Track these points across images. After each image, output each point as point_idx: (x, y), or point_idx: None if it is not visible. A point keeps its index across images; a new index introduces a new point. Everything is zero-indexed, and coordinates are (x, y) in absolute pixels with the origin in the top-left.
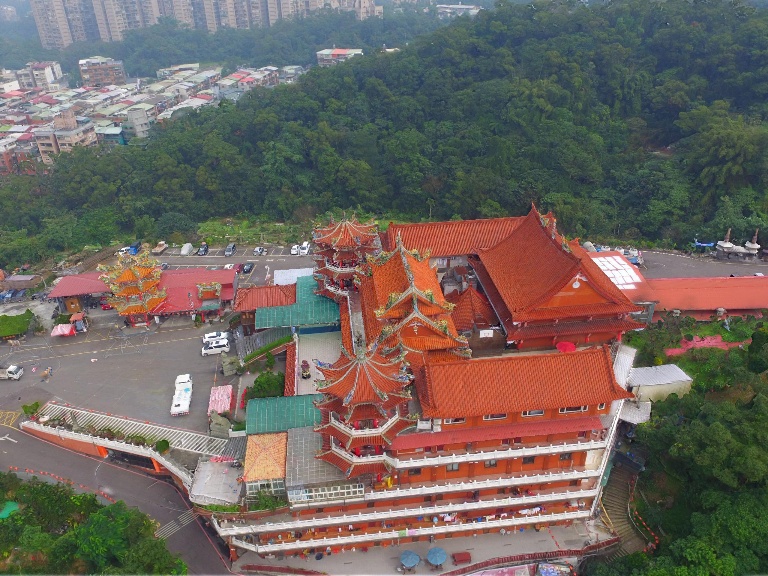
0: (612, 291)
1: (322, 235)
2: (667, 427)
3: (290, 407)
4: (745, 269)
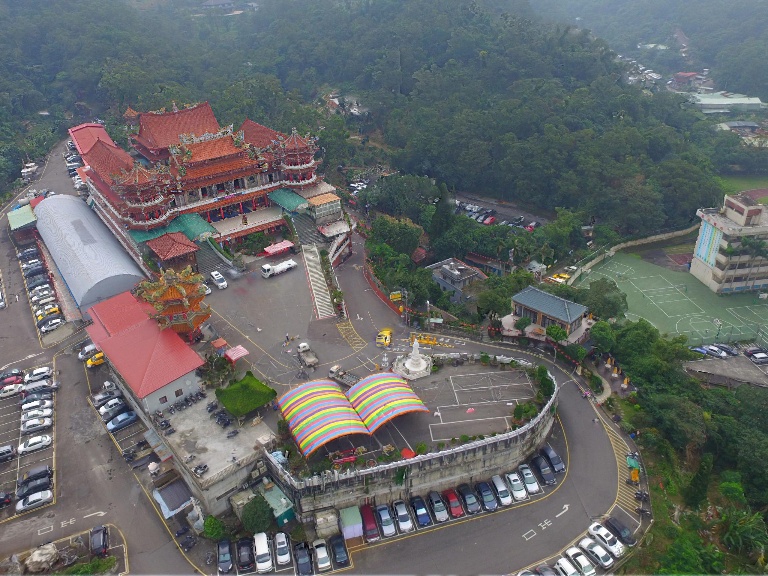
0: None
1: (152, 177)
2: None
3: (293, 196)
4: (51, 173)
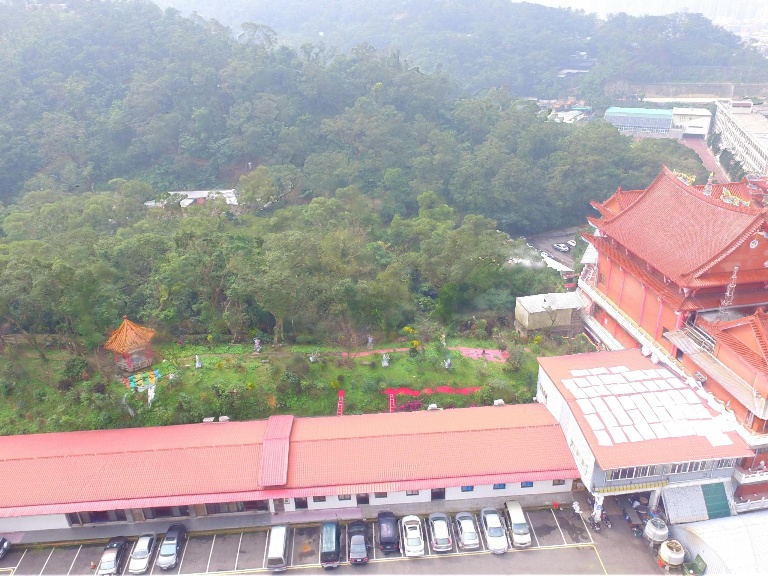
0: (621, 227)
1: None
2: (547, 274)
3: None
4: None
